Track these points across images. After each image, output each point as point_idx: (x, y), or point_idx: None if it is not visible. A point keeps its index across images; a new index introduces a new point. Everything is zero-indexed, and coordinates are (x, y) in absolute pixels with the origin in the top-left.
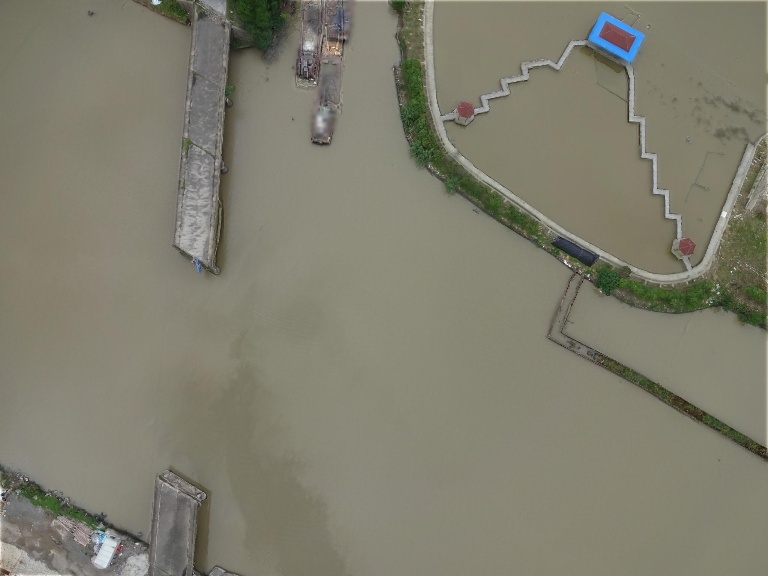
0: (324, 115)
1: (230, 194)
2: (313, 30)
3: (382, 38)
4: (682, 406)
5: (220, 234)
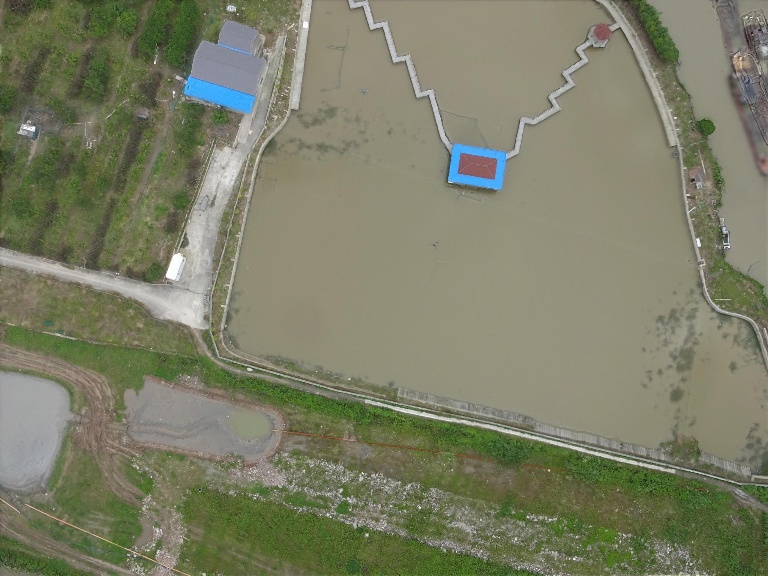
0: None
1: None
2: None
3: (703, 87)
4: None
5: None
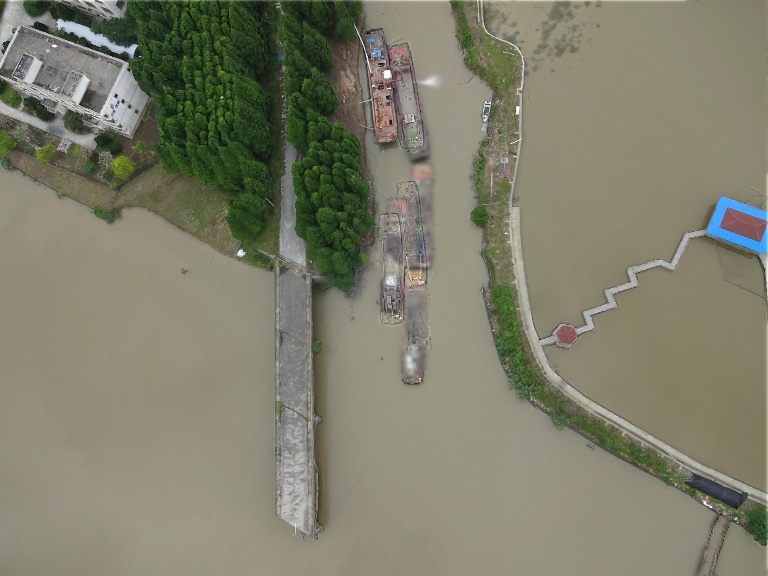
0: (413, 354)
1: (327, 437)
2: (394, 260)
3: (467, 259)
4: None
5: (318, 500)
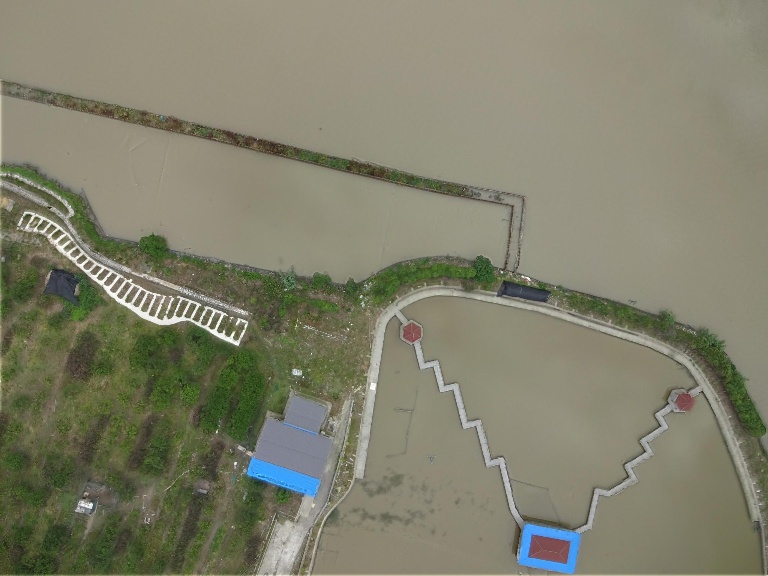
0: None
1: None
2: None
3: None
4: (375, 169)
5: None
